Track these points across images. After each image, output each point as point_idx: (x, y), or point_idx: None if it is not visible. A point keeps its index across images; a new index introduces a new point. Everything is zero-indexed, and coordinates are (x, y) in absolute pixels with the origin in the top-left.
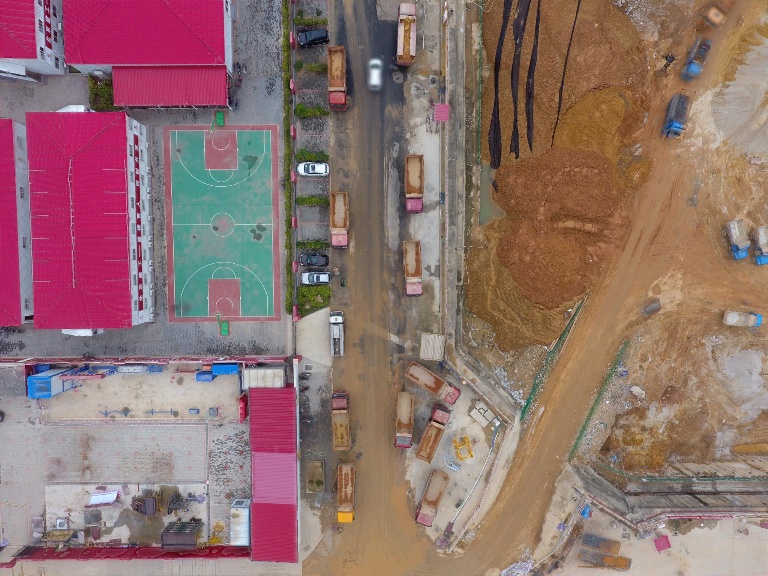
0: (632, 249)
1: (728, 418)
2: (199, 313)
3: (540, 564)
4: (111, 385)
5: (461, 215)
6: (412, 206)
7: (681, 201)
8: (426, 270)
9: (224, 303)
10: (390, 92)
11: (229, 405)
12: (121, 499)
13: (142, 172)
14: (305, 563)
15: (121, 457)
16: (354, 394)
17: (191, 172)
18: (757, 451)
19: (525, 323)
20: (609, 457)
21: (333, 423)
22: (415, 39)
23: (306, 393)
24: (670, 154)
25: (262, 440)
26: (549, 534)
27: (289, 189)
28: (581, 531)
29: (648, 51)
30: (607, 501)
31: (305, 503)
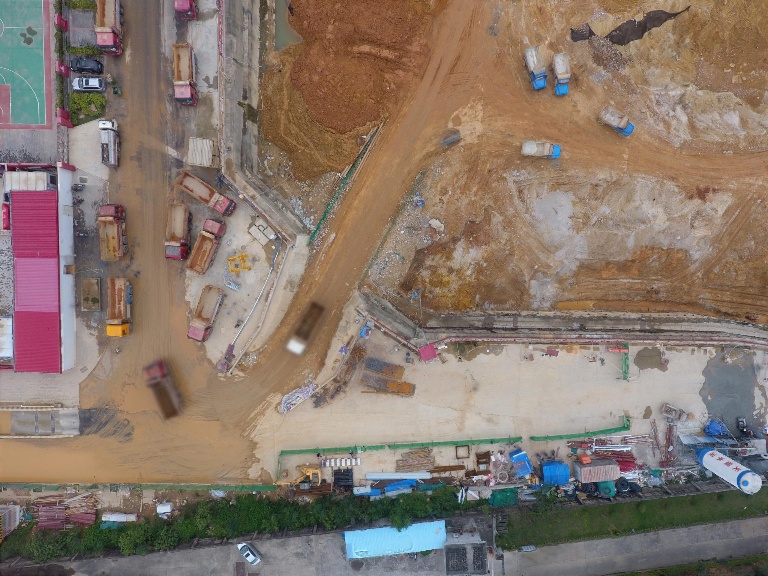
0: (431, 78)
1: (542, 265)
2: None
3: (322, 389)
4: None
5: (247, 31)
6: (179, 5)
7: (481, 29)
8: (204, 81)
9: None
10: None
11: (0, 217)
12: None
13: None
14: (82, 386)
15: None
16: (131, 209)
17: None
18: (580, 308)
19: (318, 149)
20: (409, 293)
21: (102, 232)
22: None
23: (81, 206)
24: None
25: (24, 245)
26: (331, 358)
27: None
28: (364, 355)
29: None
30: (391, 324)
31: (81, 322)
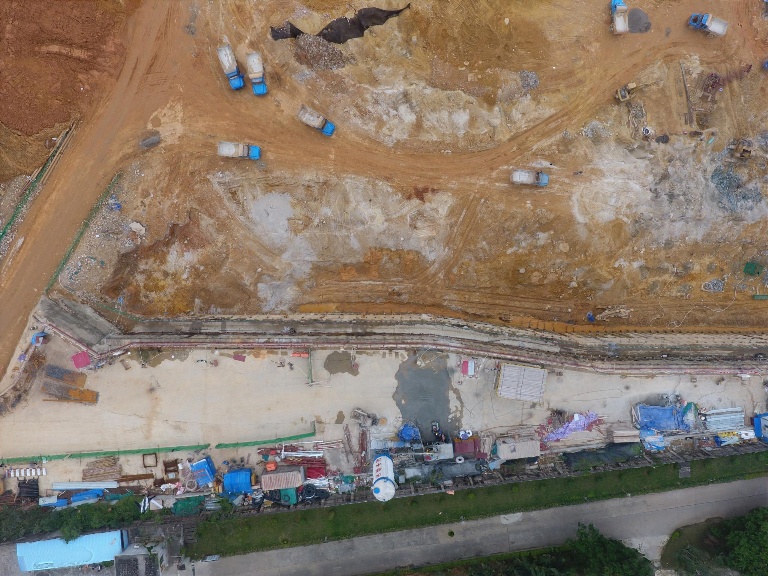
0: (128, 78)
1: (267, 268)
2: None
3: (2, 397)
4: None
5: None
6: None
7: (177, 28)
8: None
9: None
10: None
11: None
12: None
13: None
14: None
15: None
16: None
17: None
18: (323, 311)
19: (6, 151)
20: (114, 298)
21: None
22: None
23: None
24: None
25: None
26: (11, 366)
27: None
28: (43, 362)
29: None
30: (71, 331)
31: None
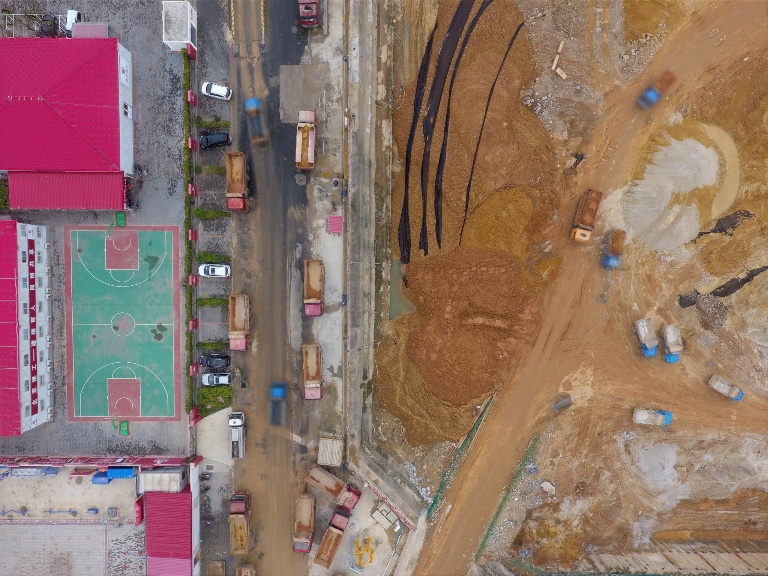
0: (542, 345)
1: (645, 509)
2: (98, 413)
3: None
4: (9, 484)
5: (367, 313)
6: (310, 311)
7: (591, 297)
8: (329, 371)
9: (124, 403)
10: (293, 194)
11: (128, 505)
12: None
13: (40, 274)
14: None
15: (18, 557)
16: (256, 494)
17: (92, 272)
18: (678, 538)
19: (433, 419)
20: (520, 552)
21: (231, 526)
22: (313, 146)
23: (207, 493)
24: (580, 251)
25: (157, 545)
26: None
27: (189, 291)
28: None
29: (558, 149)
30: None
31: None
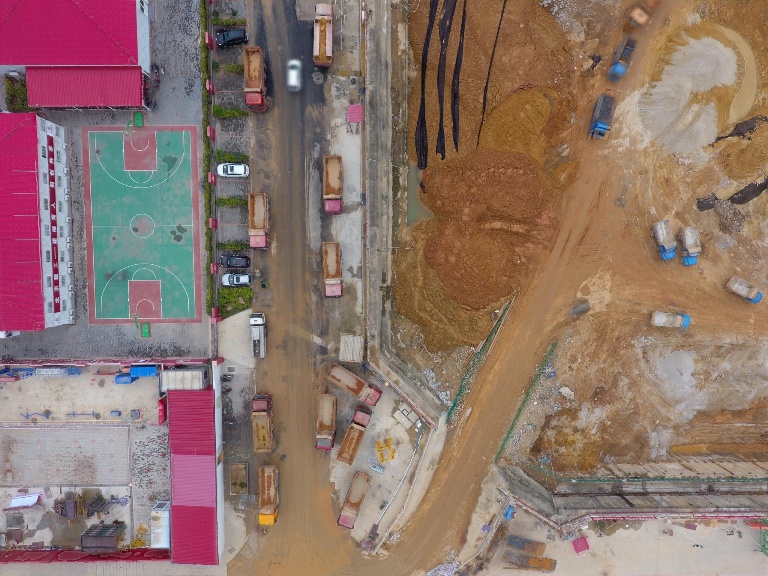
0: (560, 250)
1: (662, 419)
2: (120, 315)
3: (465, 566)
4: (32, 387)
5: (385, 216)
6: (330, 207)
7: (609, 202)
8: (348, 271)
9: (145, 305)
10: (310, 93)
11: (151, 407)
12: (43, 502)
13: (59, 173)
14: (230, 565)
15: (43, 460)
16: (277, 396)
17: (110, 173)
18: (695, 451)
19: (452, 324)
20: (539, 458)
21: (254, 425)
22: (331, 39)
23: (229, 395)
24: (597, 155)
25: (181, 442)
26: (474, 535)
27: (208, 190)
28: (506, 532)
29: (575, 51)
30: (532, 502)
31: (229, 505)
